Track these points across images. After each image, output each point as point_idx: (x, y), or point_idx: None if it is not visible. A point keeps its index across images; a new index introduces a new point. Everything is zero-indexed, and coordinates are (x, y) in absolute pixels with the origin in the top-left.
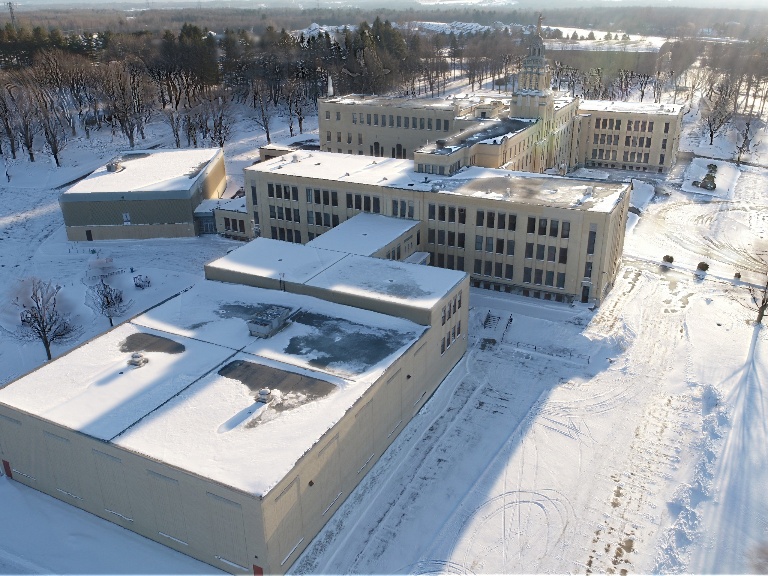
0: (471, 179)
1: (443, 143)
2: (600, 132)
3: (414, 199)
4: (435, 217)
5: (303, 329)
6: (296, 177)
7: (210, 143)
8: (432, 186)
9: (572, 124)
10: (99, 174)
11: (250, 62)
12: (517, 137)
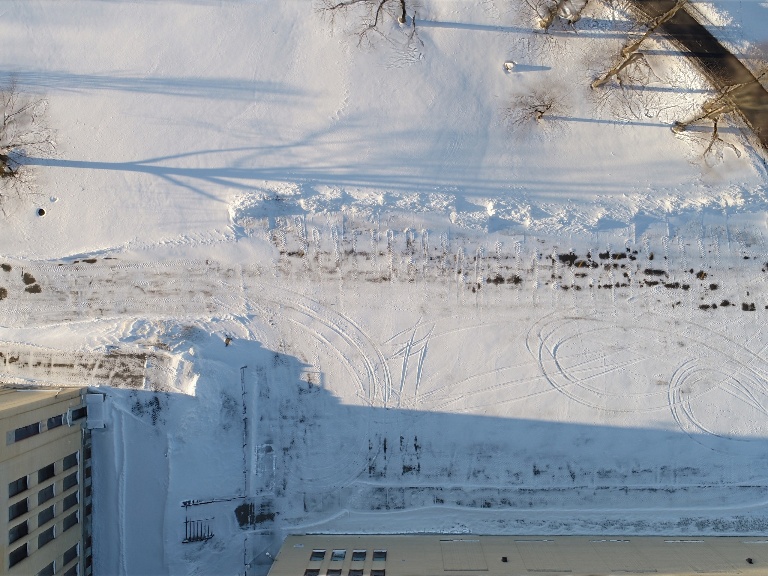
0: None
1: None
2: None
3: None
4: None
5: None
6: None
7: None
8: None
9: None
10: None
11: None
12: None
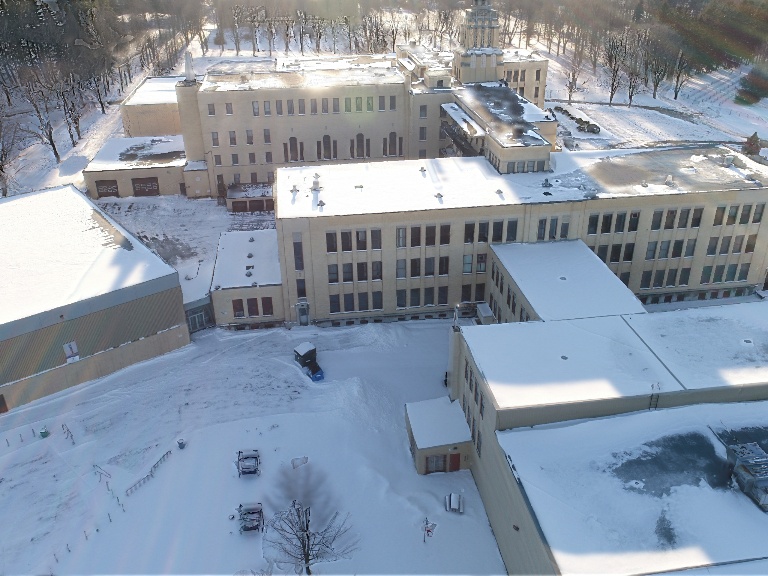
0: (580, 171)
1: (523, 129)
2: None
3: (572, 213)
4: (597, 230)
5: None
6: (381, 215)
7: (6, 178)
8: (593, 191)
9: None
10: None
11: None
12: None
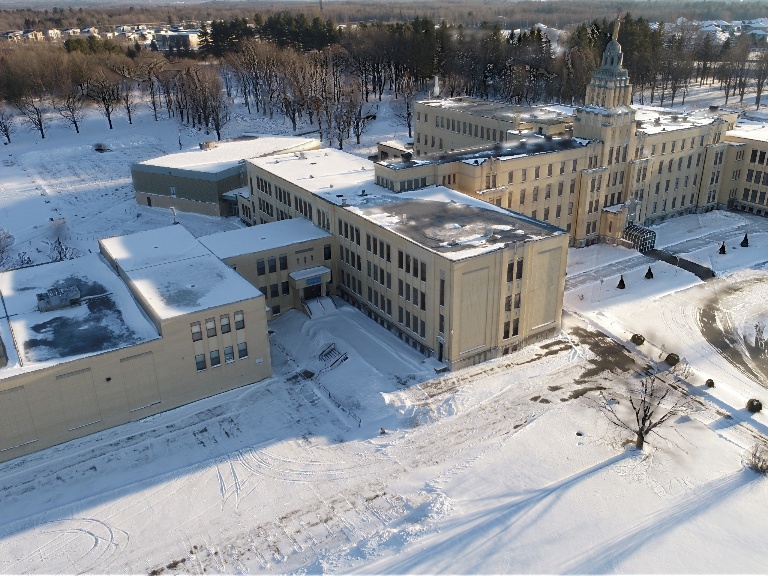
0: (410, 199)
1: (407, 156)
2: (755, 168)
3: (328, 211)
4: (343, 233)
5: (78, 312)
6: (269, 173)
7: (333, 133)
8: (342, 200)
9: (704, 153)
10: (191, 150)
11: (450, 57)
12: (529, 160)
